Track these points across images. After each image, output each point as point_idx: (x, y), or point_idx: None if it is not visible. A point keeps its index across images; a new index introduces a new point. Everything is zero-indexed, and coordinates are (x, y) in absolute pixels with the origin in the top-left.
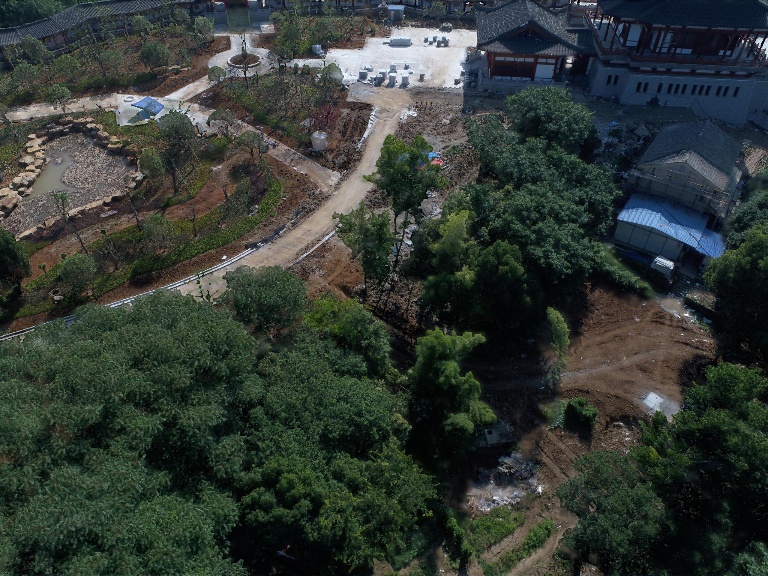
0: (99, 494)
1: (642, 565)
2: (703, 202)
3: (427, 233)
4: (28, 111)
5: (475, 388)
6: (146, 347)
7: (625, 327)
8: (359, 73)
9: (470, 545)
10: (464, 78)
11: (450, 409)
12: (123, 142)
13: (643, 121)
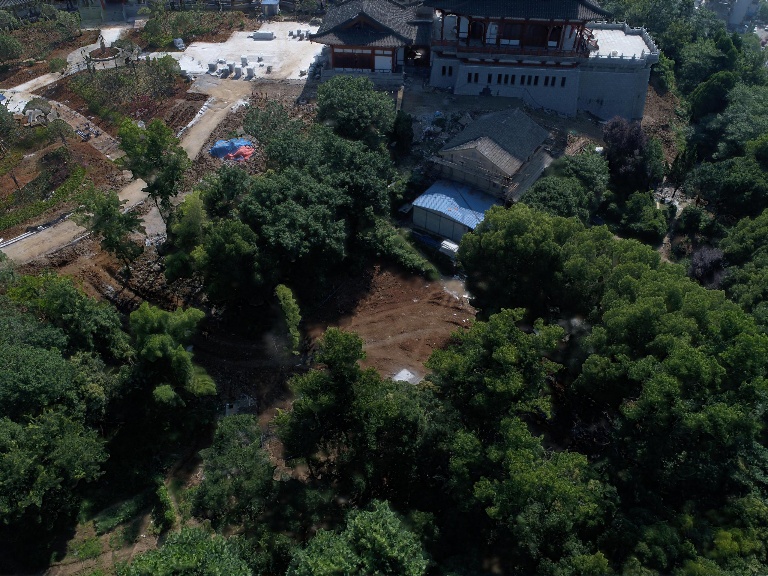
0: None
1: (244, 519)
2: (497, 187)
3: (177, 214)
4: None
5: (183, 360)
6: None
7: (400, 308)
8: (208, 65)
9: (179, 512)
10: None
11: (168, 382)
12: None
13: (469, 111)
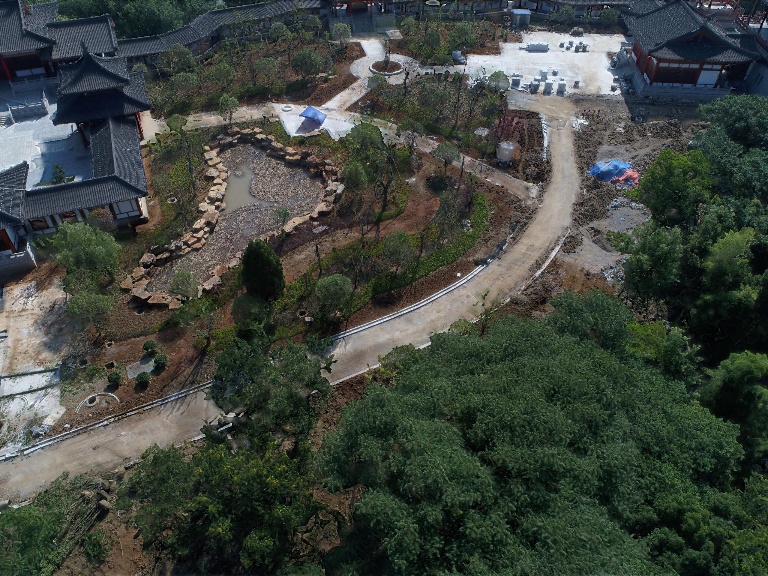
0: (598, 546)
1: None
2: None
3: (690, 250)
4: (190, 122)
5: None
6: (554, 382)
7: None
8: (512, 80)
9: None
10: (620, 84)
11: (751, 434)
12: (302, 154)
13: None
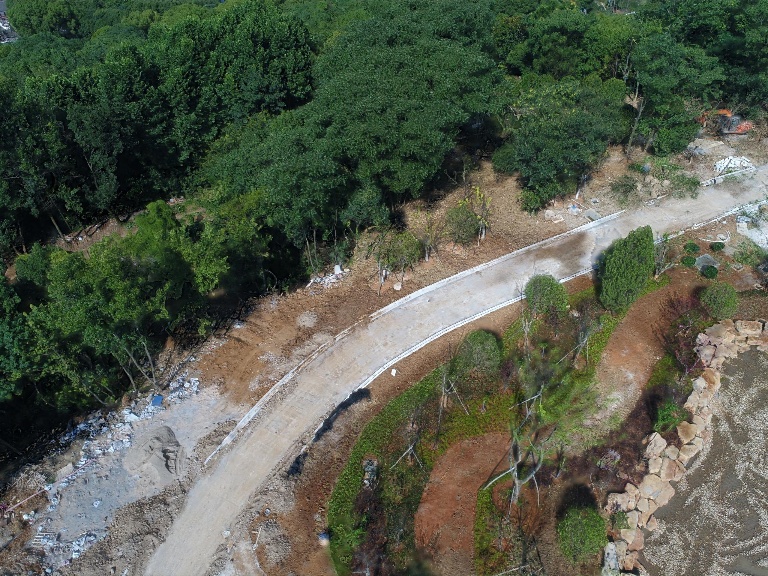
0: None
1: None
2: None
3: None
4: None
5: None
6: None
7: None
8: None
9: None
10: None
11: None
12: None
13: None
